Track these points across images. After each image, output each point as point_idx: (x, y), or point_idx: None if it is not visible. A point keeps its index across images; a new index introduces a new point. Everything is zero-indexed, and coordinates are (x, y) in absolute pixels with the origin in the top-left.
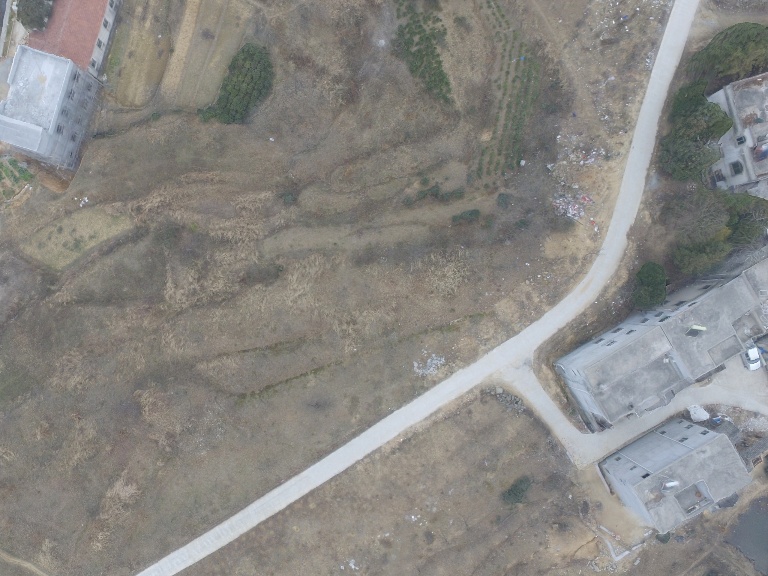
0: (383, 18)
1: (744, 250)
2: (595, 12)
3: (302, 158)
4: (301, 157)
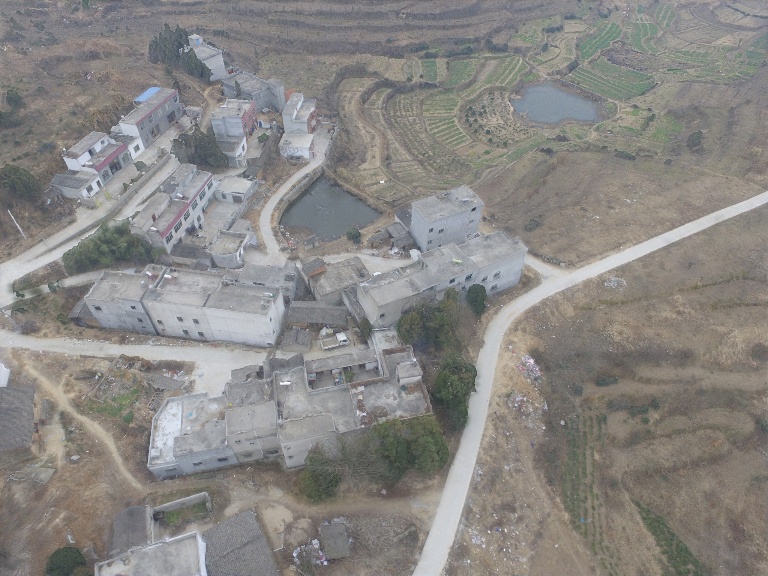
0: None
1: None
2: (525, 546)
3: (762, 471)
4: (764, 472)
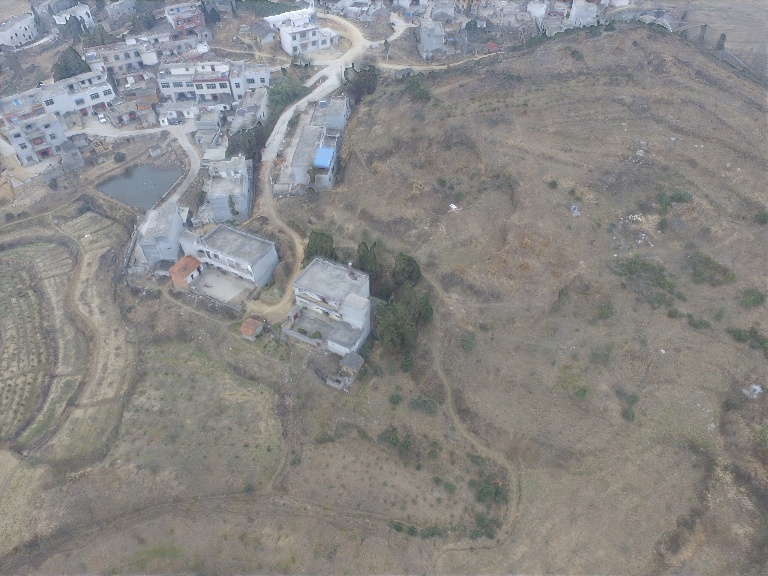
0: (1, 87)
1: (73, 72)
2: None
3: None
4: None
